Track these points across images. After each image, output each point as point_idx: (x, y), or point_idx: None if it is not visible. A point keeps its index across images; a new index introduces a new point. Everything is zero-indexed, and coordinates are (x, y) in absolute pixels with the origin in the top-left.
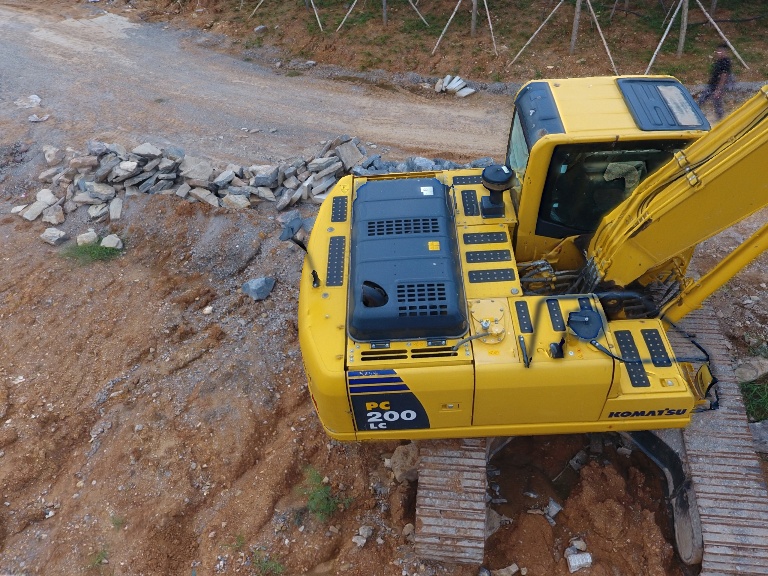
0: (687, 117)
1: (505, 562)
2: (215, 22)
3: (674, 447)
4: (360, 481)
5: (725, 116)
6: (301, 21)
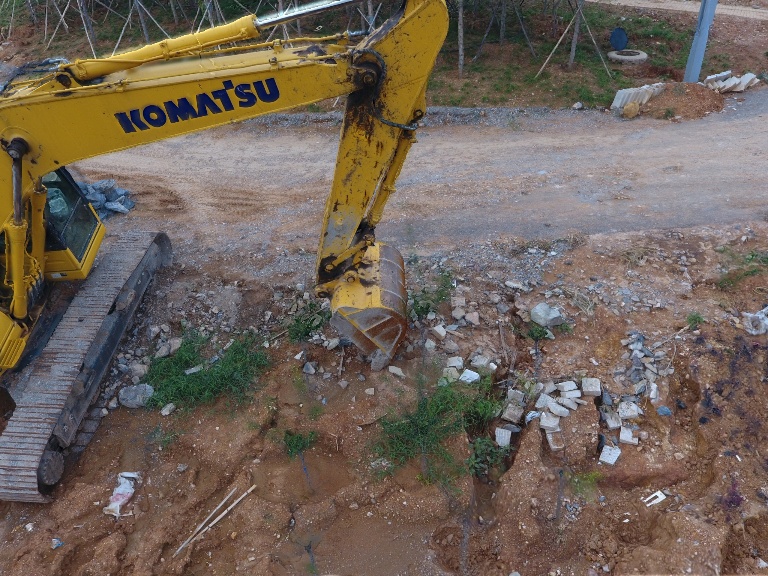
0: None
1: None
2: (17, 54)
3: (17, 402)
4: None
5: None
6: (83, 54)
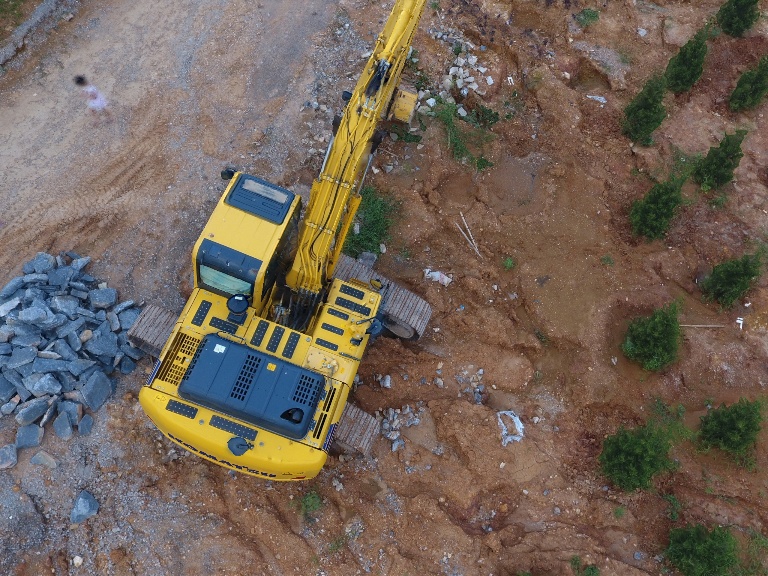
0: (279, 196)
1: (373, 416)
2: None
3: None
4: None
5: (72, 52)
6: None
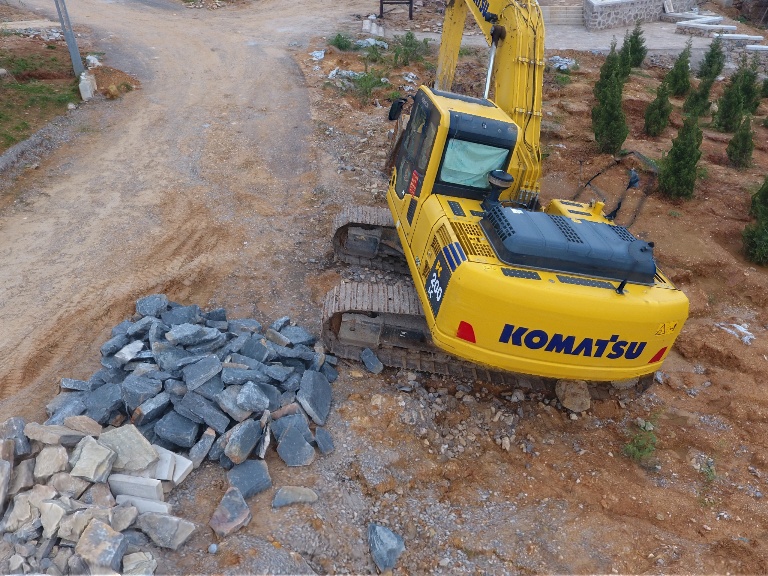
0: None
1: None
2: None
3: None
4: (600, 433)
5: (53, 186)
6: None
